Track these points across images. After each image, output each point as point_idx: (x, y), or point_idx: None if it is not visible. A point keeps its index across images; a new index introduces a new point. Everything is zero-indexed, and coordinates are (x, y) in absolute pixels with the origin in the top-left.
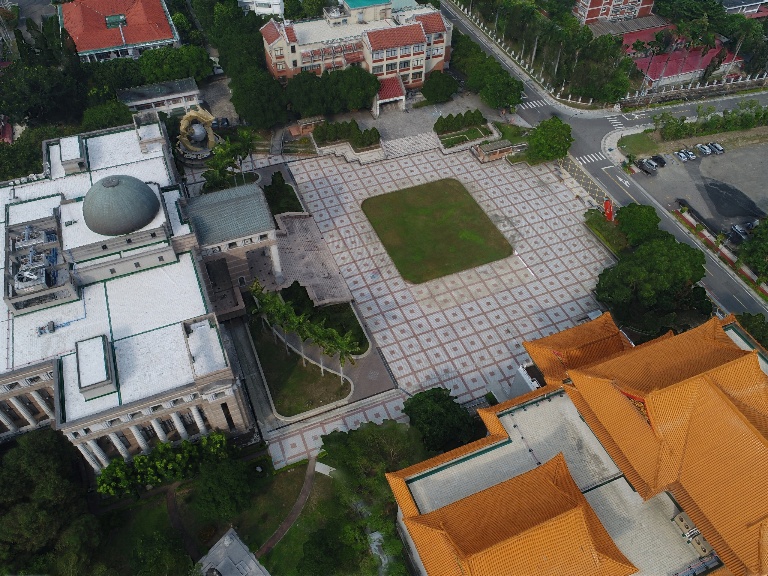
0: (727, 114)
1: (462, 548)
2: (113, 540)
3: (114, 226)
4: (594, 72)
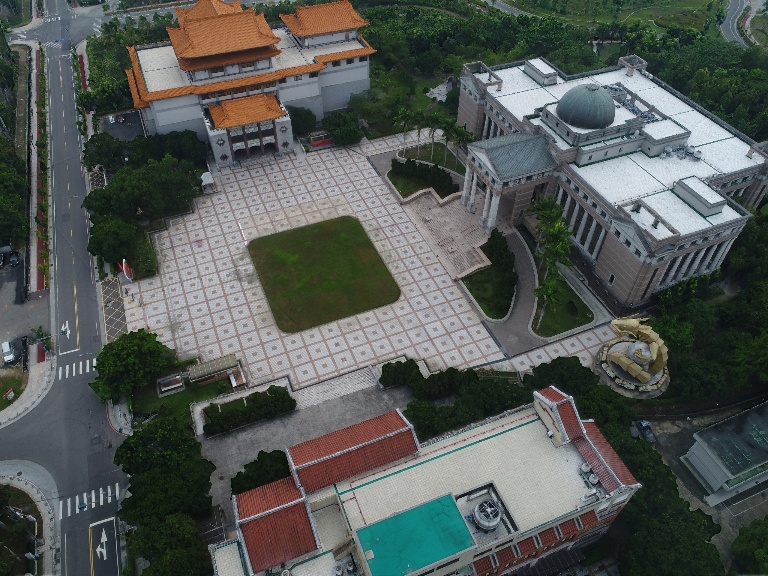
0: None
1: (348, 9)
2: None
3: None
4: None
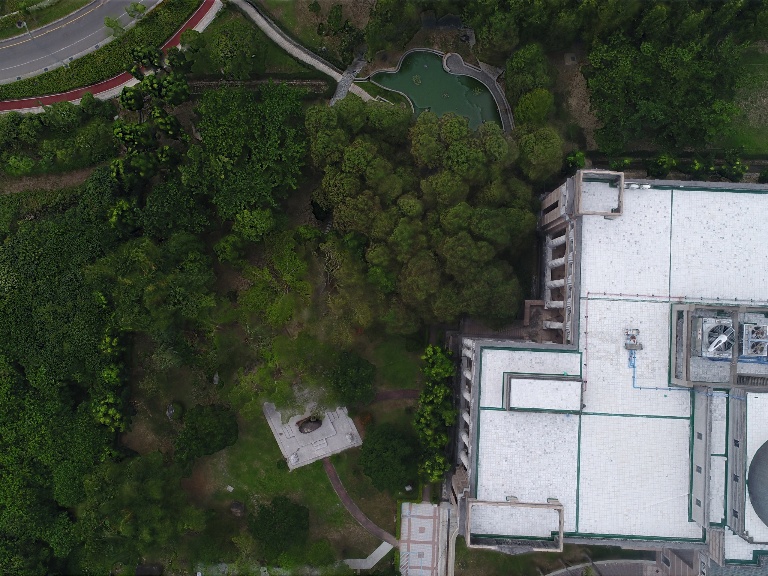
0: None
1: None
2: None
3: (763, 473)
4: None
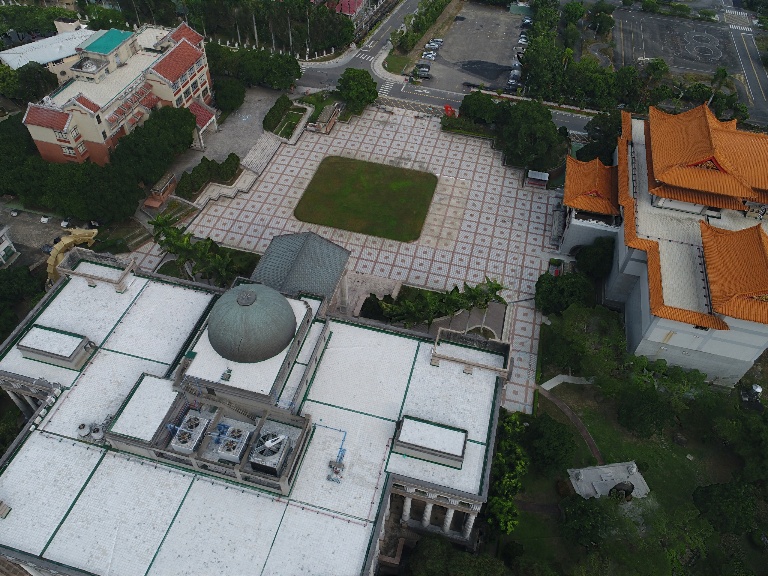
0: (417, 17)
1: (759, 289)
2: None
3: (285, 336)
4: (324, 25)
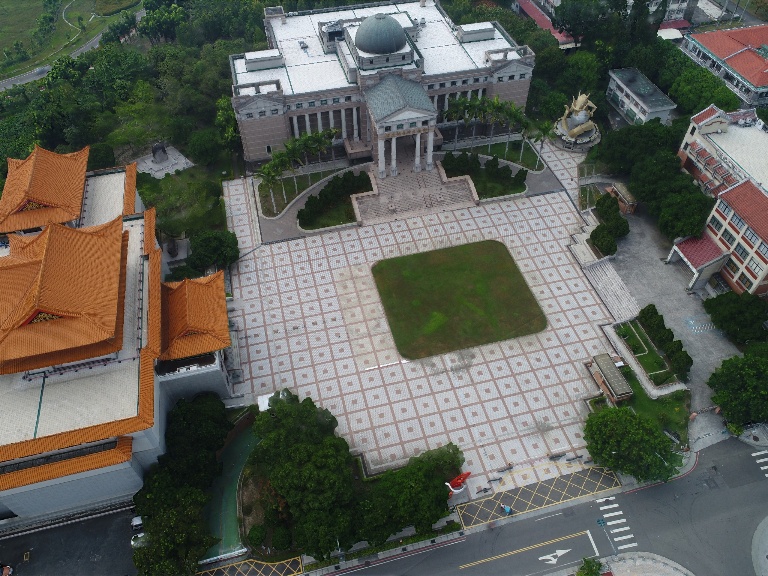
0: None
1: (49, 154)
2: (211, 127)
3: None
4: None
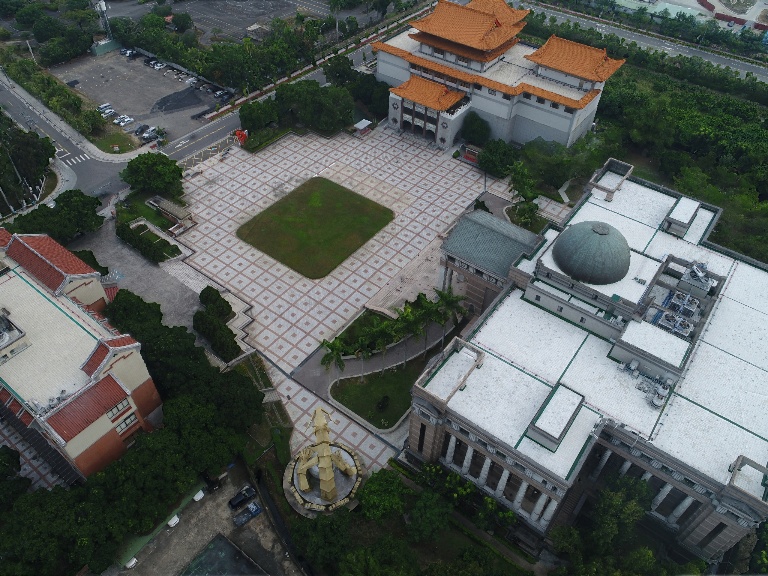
0: None
1: (599, 59)
2: None
3: None
4: None
